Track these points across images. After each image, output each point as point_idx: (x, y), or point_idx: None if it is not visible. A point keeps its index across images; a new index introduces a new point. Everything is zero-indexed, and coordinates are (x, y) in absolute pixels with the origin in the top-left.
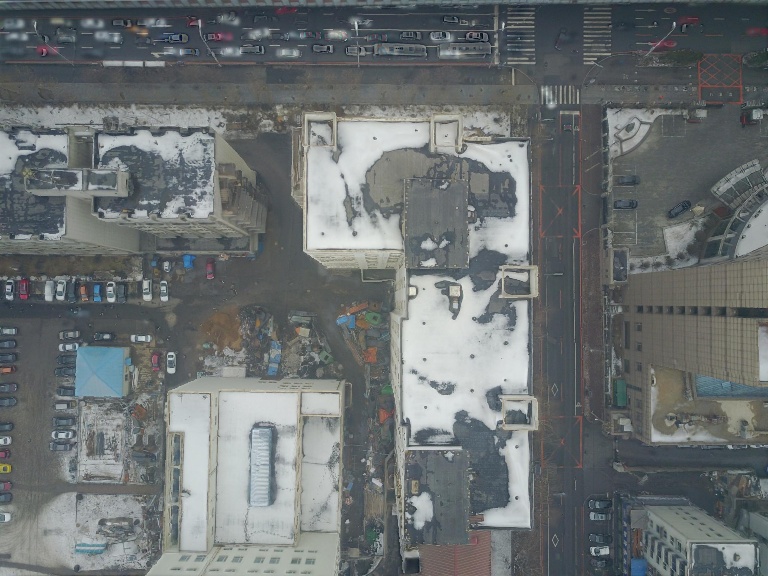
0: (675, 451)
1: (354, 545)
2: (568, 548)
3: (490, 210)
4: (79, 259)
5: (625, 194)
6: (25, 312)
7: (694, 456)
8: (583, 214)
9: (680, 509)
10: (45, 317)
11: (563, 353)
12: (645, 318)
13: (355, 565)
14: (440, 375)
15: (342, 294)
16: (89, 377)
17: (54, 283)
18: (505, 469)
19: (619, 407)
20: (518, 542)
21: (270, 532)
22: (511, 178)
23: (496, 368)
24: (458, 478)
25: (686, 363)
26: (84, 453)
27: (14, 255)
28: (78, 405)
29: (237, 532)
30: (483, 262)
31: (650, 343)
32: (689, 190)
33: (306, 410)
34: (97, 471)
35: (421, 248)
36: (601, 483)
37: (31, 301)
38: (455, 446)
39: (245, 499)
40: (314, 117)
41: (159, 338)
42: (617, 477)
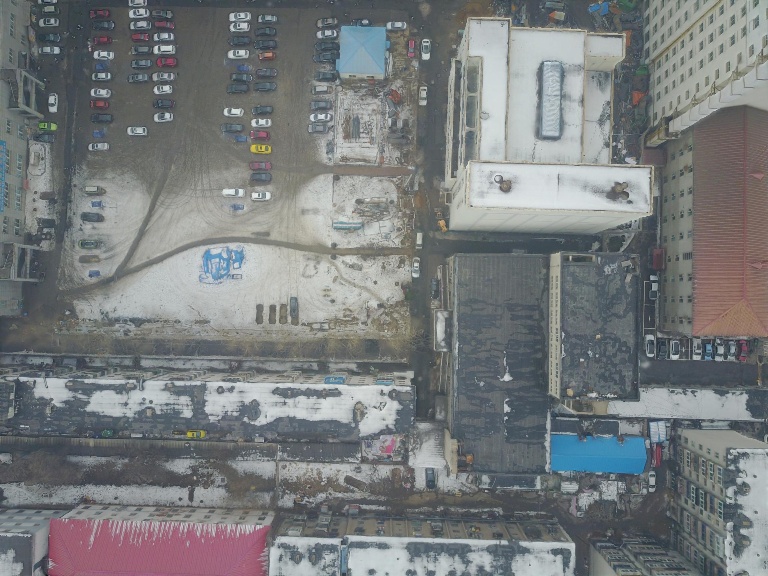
0: None
1: None
2: None
3: None
4: None
5: None
6: (283, 2)
7: None
8: None
9: None
10: (303, 7)
11: None
12: None
13: (606, 244)
14: None
15: None
16: (357, 49)
17: None
18: None
19: None
20: None
21: None
22: None
23: None
24: None
25: None
26: (340, 136)
27: None
28: (335, 90)
29: None
30: None
31: None
32: None
33: (589, 53)
34: (353, 154)
35: None
36: None
37: None
38: None
39: (532, 134)
40: None
41: (413, 27)
42: None
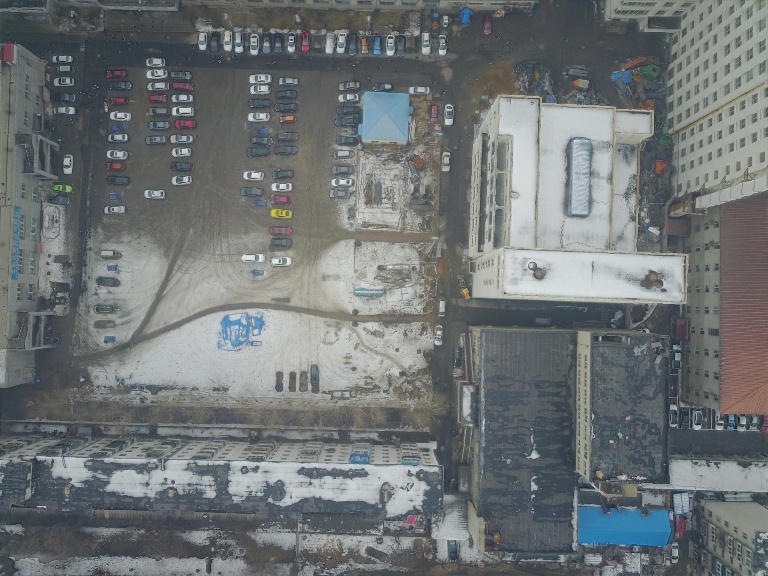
0: None
1: None
2: None
3: None
4: (358, 13)
5: None
6: (305, 64)
7: None
8: None
9: None
10: (324, 70)
11: None
12: None
13: (630, 313)
14: None
15: (616, 51)
16: (381, 116)
17: (334, 36)
18: None
19: None
20: None
21: (585, 244)
22: None
23: None
24: None
25: None
26: (362, 201)
27: (295, 9)
28: (357, 155)
29: (553, 243)
30: None
31: None
32: None
33: (618, 129)
34: (375, 219)
35: None
36: None
37: (310, 54)
38: None
39: (561, 211)
40: None
41: (436, 92)
42: None
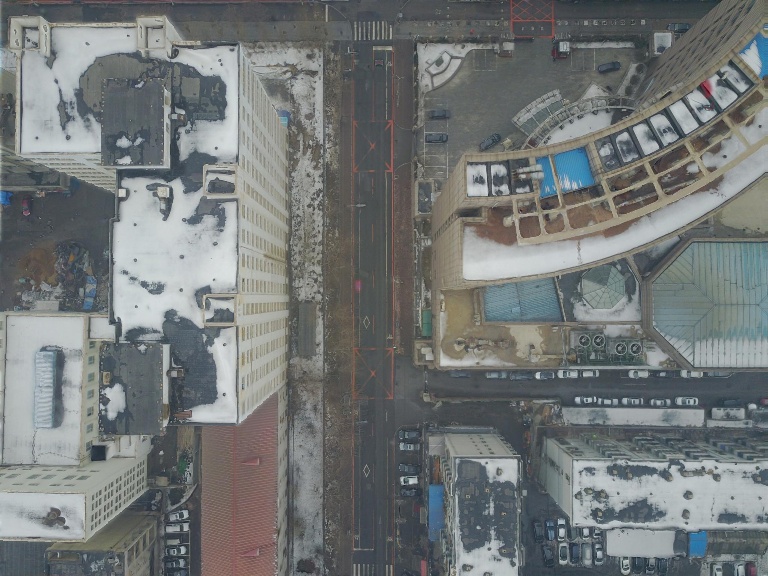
0: (485, 382)
1: (166, 475)
2: (379, 478)
3: (200, 113)
4: None
5: (436, 128)
6: None
7: (503, 387)
8: (395, 149)
9: (478, 436)
10: None
11: (375, 286)
12: (436, 245)
13: (168, 495)
14: (150, 275)
15: None
16: None
17: None
18: (213, 366)
19: (425, 337)
20: (330, 472)
21: (57, 453)
22: (222, 82)
23: (205, 268)
24: (151, 370)
25: (444, 279)
26: None
27: None
28: None
29: (25, 453)
30: (194, 164)
31: (437, 268)
32: (500, 124)
33: (95, 335)
34: None
35: (116, 146)
36: (412, 414)
37: None
38: (164, 344)
39: (32, 421)
40: (26, 23)
41: None
42: (427, 408)
